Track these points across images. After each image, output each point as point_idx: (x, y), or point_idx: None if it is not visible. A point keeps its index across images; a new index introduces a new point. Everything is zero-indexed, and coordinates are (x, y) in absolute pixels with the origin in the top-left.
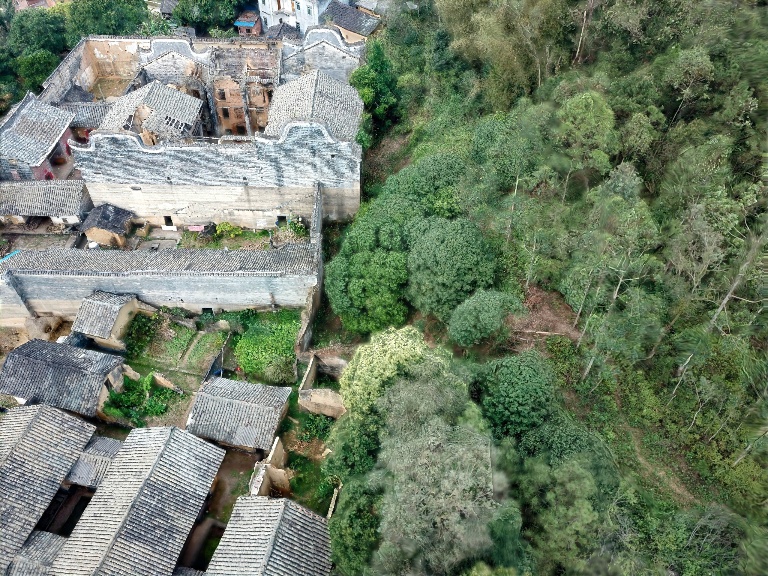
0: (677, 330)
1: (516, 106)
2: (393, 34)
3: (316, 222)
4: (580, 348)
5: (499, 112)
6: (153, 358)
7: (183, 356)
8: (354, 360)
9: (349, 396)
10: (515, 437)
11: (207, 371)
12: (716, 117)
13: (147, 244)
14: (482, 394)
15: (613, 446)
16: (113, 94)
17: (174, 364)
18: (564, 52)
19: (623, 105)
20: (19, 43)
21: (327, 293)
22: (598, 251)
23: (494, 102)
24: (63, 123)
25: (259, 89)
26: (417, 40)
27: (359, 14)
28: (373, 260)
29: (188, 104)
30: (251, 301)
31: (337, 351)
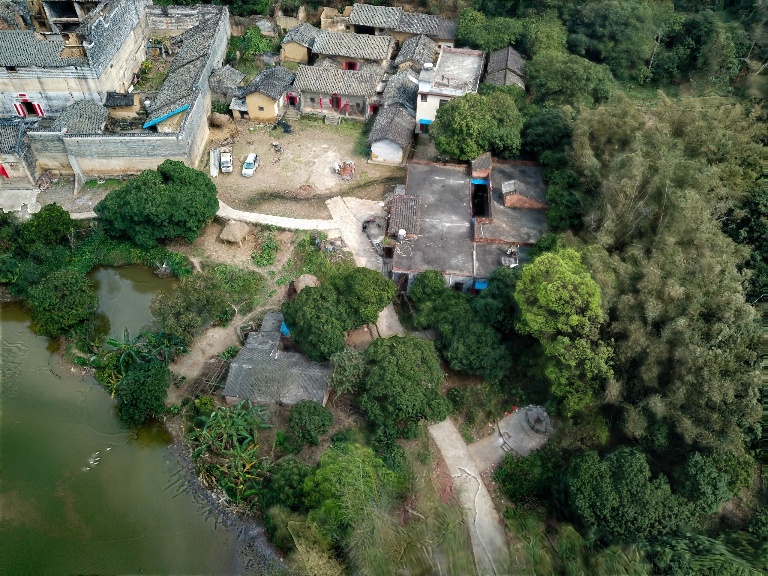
0: None
1: None
2: None
3: None
4: None
5: None
6: None
7: None
8: None
9: None
10: None
11: (272, 52)
12: None
13: None
14: None
15: None
16: None
17: None
18: None
19: None
20: None
21: None
22: None
23: None
24: None
25: None
26: None
27: None
28: None
29: None
30: None
31: None
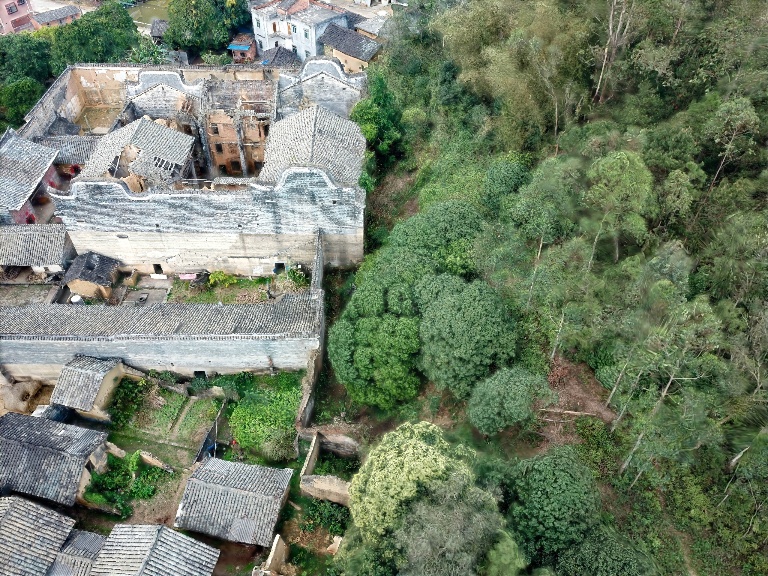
0: (723, 413)
1: (530, 145)
2: (395, 62)
3: (317, 275)
4: (615, 433)
5: (512, 152)
6: (140, 429)
7: (173, 426)
8: (365, 468)
9: (361, 513)
10: (551, 556)
11: (199, 448)
12: (764, 176)
13: (135, 294)
14: (511, 500)
15: (659, 557)
16: (100, 125)
17: (163, 436)
18: (583, 89)
19: (658, 160)
20: (2, 71)
21: (331, 361)
22: (640, 336)
23: (506, 141)
24: (46, 161)
25: (254, 123)
26: (421, 69)
27: (358, 38)
28: (381, 328)
29: (179, 142)
30: (247, 364)
31: (343, 429)
